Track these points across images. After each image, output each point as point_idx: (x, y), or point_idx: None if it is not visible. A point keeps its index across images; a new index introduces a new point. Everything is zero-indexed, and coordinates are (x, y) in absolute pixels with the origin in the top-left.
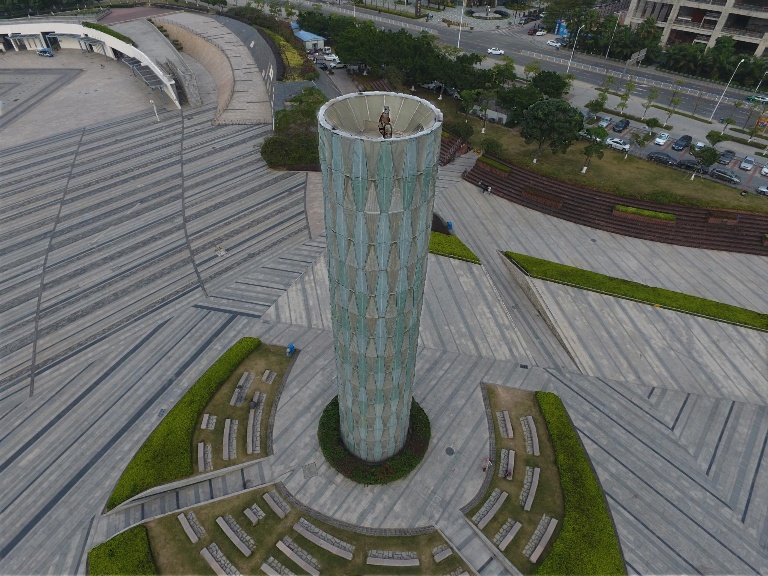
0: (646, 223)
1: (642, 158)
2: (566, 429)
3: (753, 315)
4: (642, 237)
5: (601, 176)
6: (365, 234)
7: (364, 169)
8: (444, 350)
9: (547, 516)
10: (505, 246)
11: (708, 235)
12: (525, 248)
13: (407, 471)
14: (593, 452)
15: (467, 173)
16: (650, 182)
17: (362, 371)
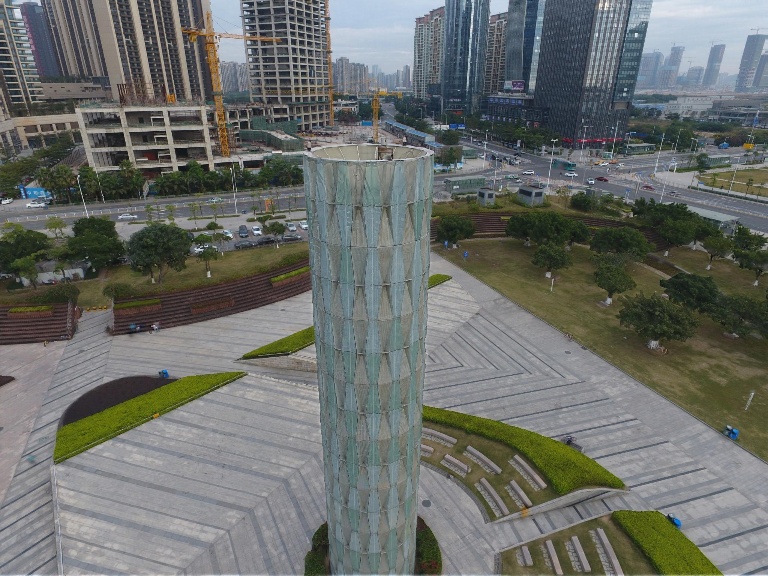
0: (298, 280)
1: (232, 250)
2: (443, 412)
3: None
4: (305, 290)
5: (225, 273)
6: (420, 265)
7: (422, 189)
8: (313, 455)
9: (510, 460)
10: (234, 354)
11: None
12: (250, 345)
13: (438, 547)
14: (464, 411)
15: (113, 328)
16: (259, 261)
17: (408, 454)
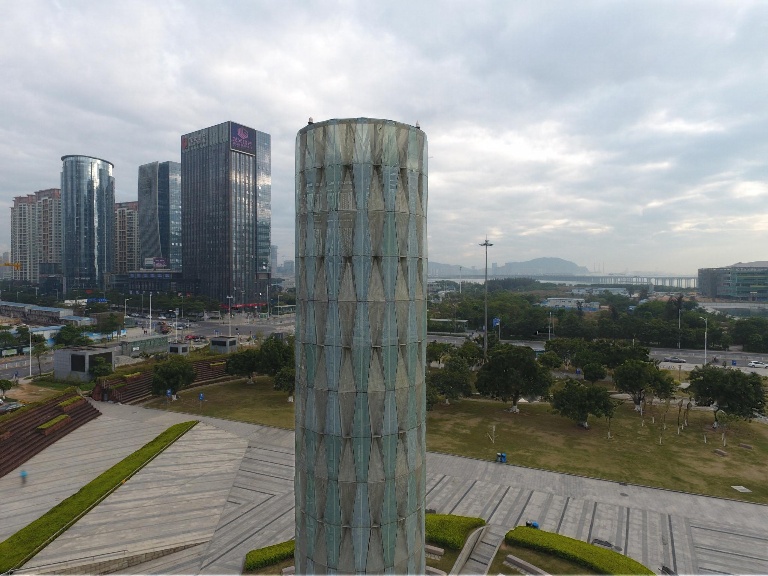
0: None
1: None
2: None
3: (147, 447)
4: None
5: None
6: None
7: None
8: None
9: None
10: None
11: (8, 454)
12: None
13: None
14: None
15: None
16: None
17: None
